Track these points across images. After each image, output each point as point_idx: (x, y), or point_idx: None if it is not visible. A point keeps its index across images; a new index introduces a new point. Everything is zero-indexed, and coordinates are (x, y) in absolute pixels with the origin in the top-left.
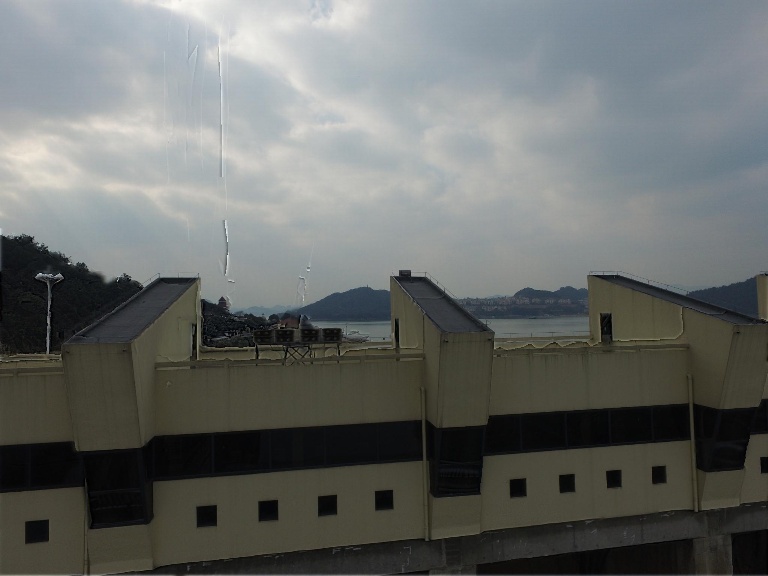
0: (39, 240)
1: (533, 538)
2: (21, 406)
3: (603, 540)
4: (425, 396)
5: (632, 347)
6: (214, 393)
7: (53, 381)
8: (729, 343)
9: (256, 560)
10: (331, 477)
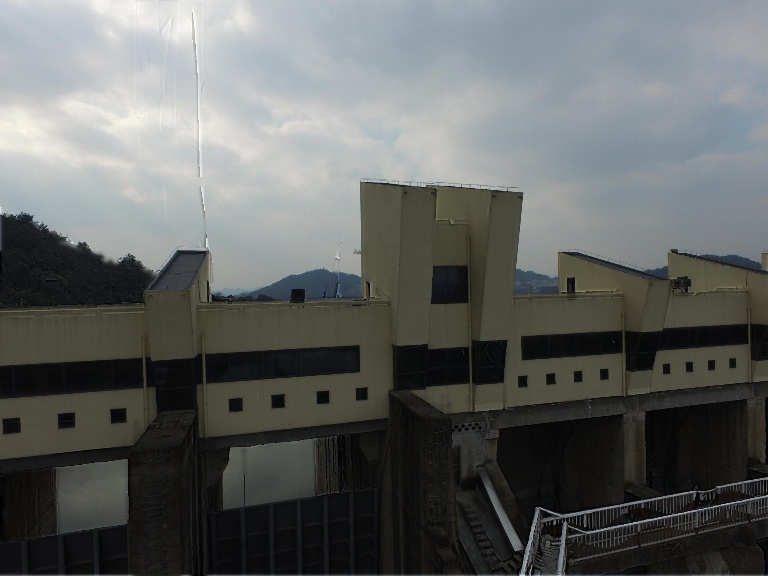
0: (39, 219)
1: None
2: (596, 313)
3: None
4: (750, 311)
5: None
6: (668, 309)
7: (608, 301)
8: None
9: (682, 392)
10: (713, 351)
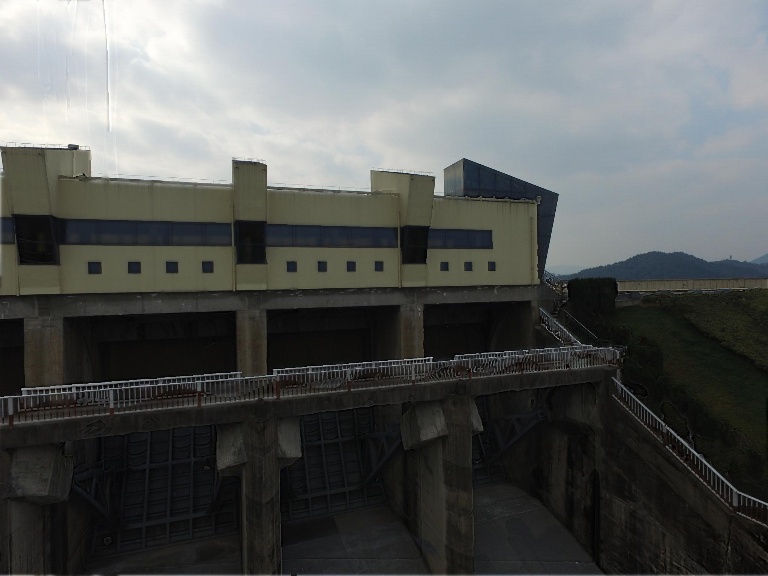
0: None
1: (109, 303)
2: None
3: (166, 307)
4: None
5: (189, 183)
6: None
7: None
8: (233, 175)
9: None
10: None
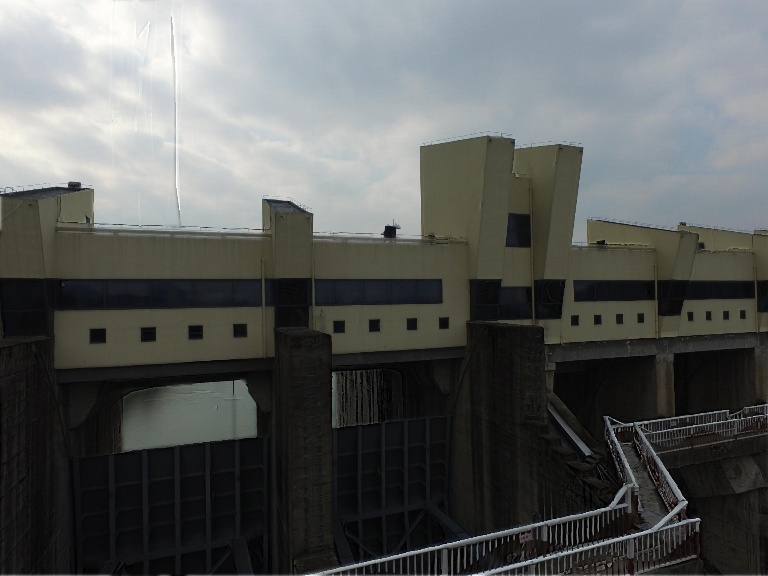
0: None
1: None
2: (634, 264)
3: None
4: (756, 270)
5: None
6: None
7: (643, 254)
8: None
9: (703, 338)
10: (727, 303)
